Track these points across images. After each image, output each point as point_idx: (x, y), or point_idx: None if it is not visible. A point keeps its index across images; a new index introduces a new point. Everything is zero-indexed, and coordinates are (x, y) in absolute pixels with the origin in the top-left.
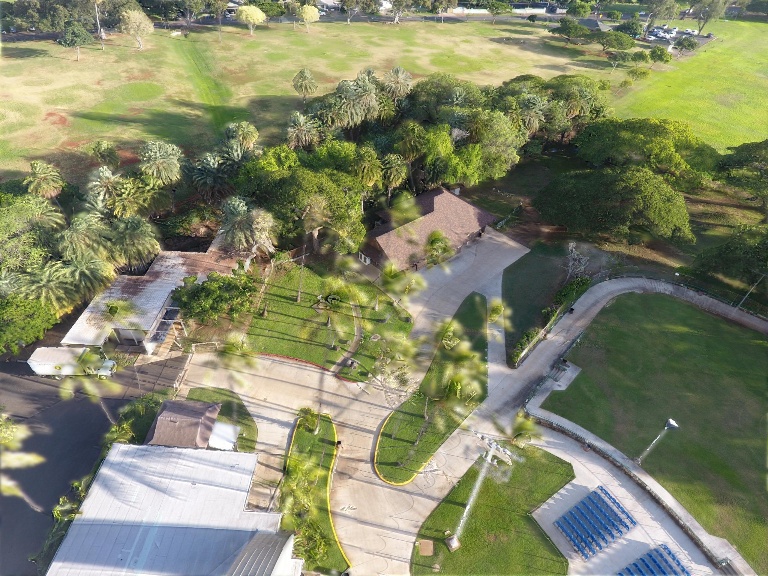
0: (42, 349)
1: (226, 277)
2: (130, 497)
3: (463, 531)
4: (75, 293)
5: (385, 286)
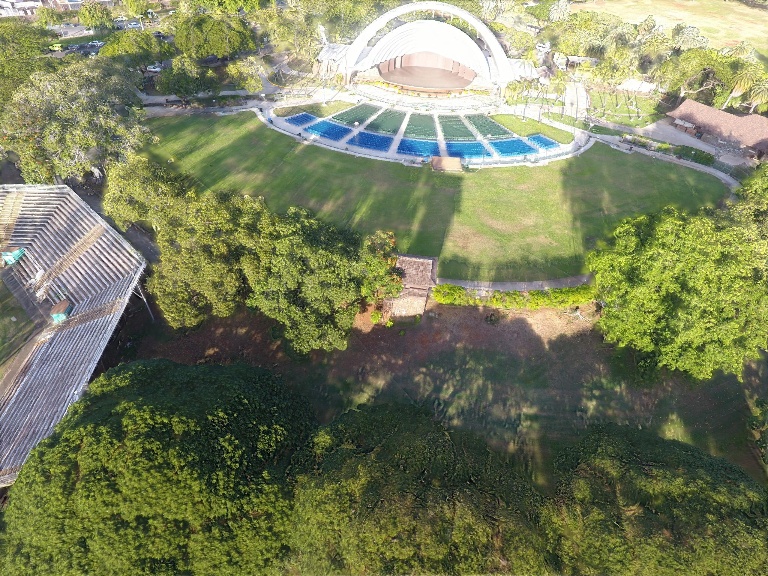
0: (562, 53)
1: (617, 62)
2: None
3: None
4: (591, 51)
5: None
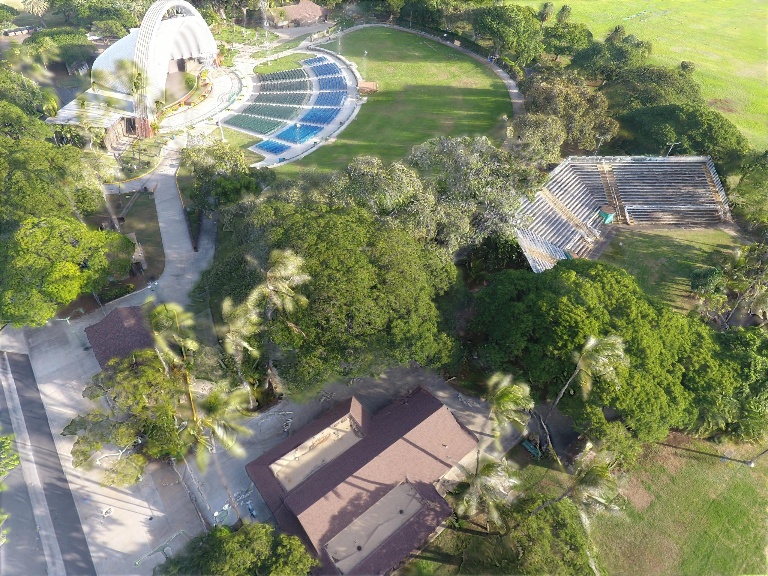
0: None
1: None
2: None
3: (274, 63)
4: None
5: (273, 30)
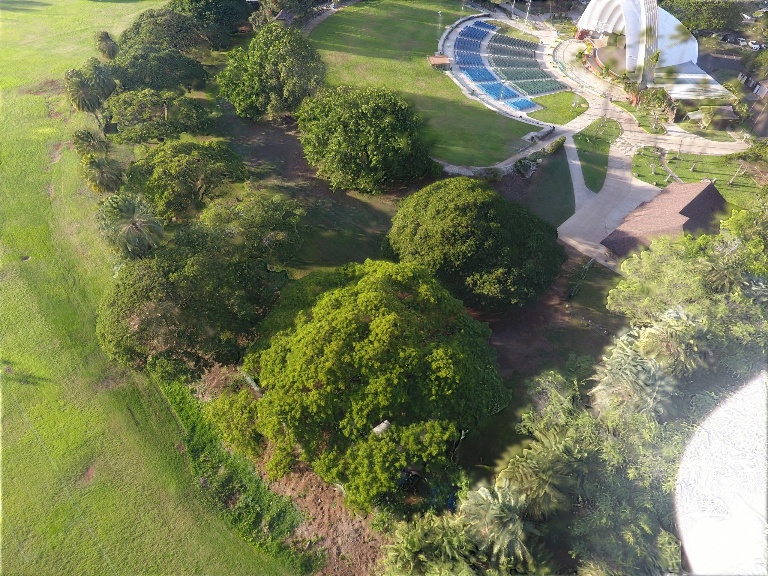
0: None
1: None
2: (710, 88)
3: None
4: None
5: None
